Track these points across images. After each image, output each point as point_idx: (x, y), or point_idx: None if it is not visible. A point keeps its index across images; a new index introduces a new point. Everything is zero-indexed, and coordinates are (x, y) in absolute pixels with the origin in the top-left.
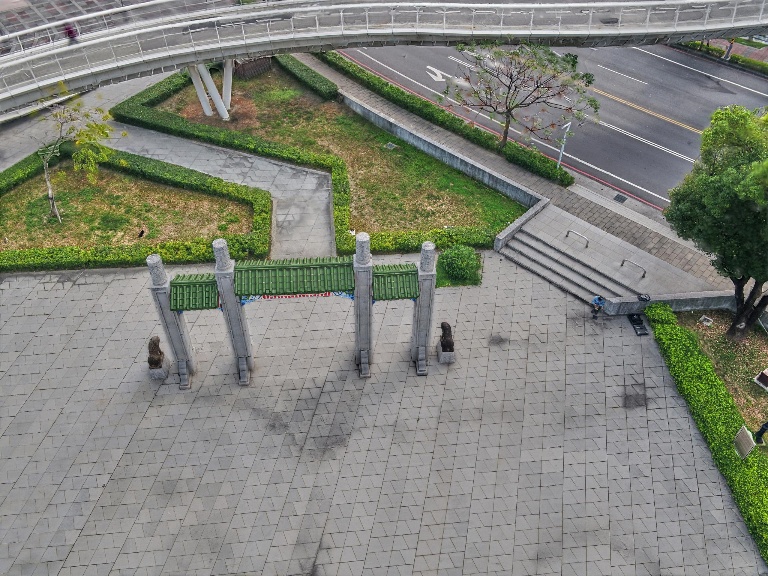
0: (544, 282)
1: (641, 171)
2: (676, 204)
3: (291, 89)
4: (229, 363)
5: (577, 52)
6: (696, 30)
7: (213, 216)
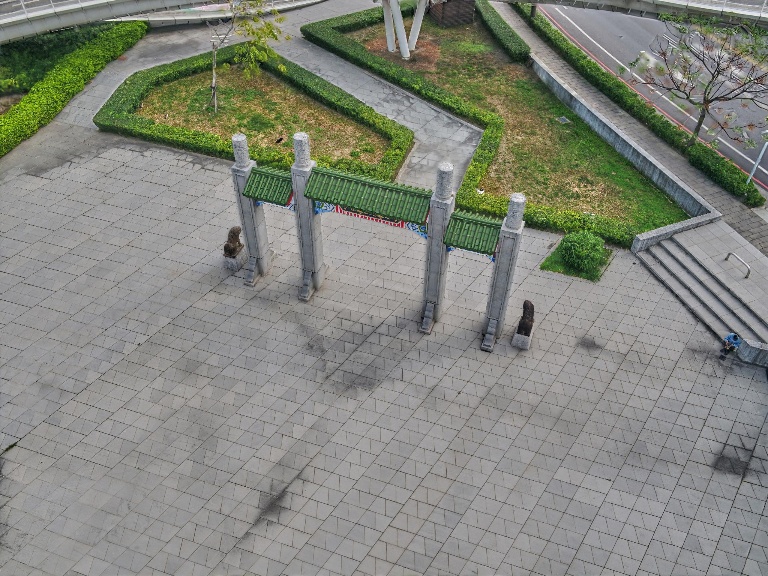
0: (676, 301)
1: None
2: None
3: (483, 44)
4: (300, 276)
5: None
6: None
7: (351, 142)
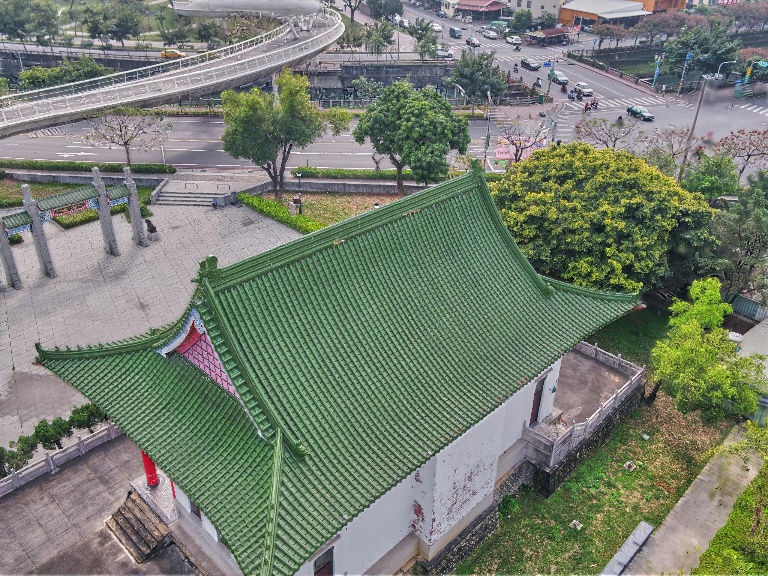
0: (185, 206)
1: (208, 160)
2: (226, 142)
3: None
4: (38, 275)
5: None
6: (201, 86)
7: None
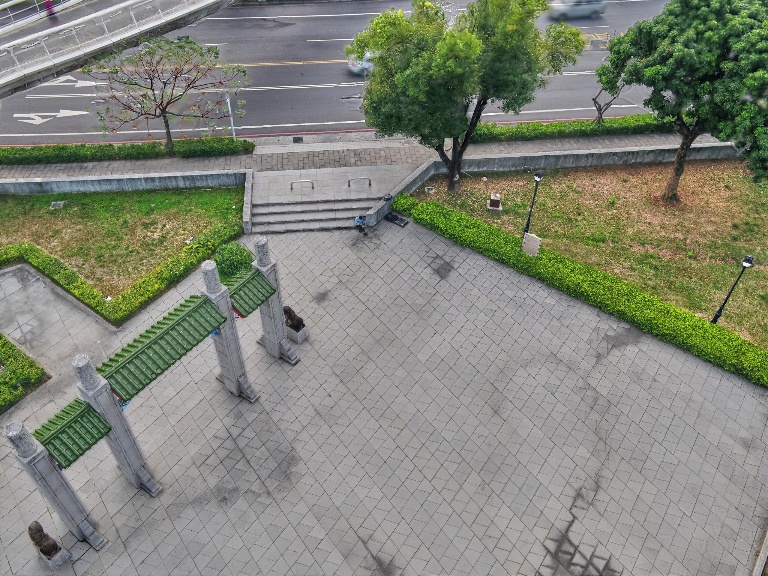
0: (307, 233)
1: (291, 112)
2: (374, 111)
3: None
4: (121, 489)
5: (182, 33)
6: None
7: None
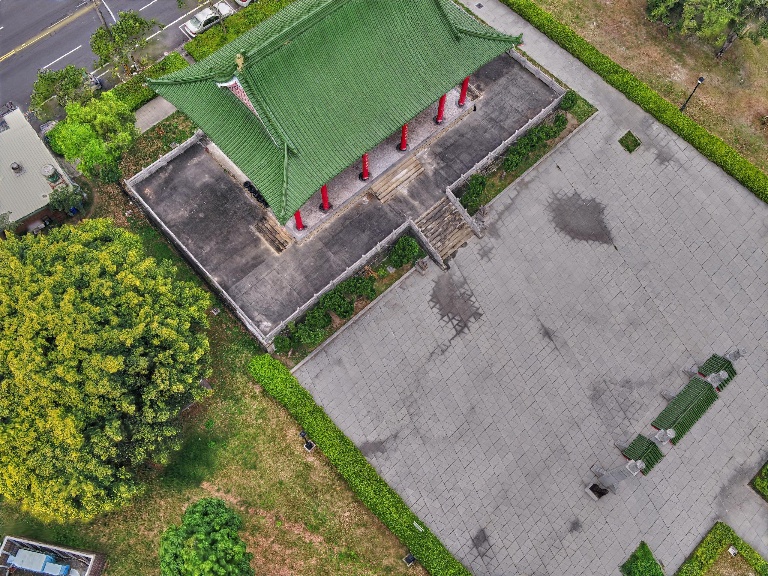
0: None
1: None
2: None
3: None
4: None
5: None
6: None
7: None
